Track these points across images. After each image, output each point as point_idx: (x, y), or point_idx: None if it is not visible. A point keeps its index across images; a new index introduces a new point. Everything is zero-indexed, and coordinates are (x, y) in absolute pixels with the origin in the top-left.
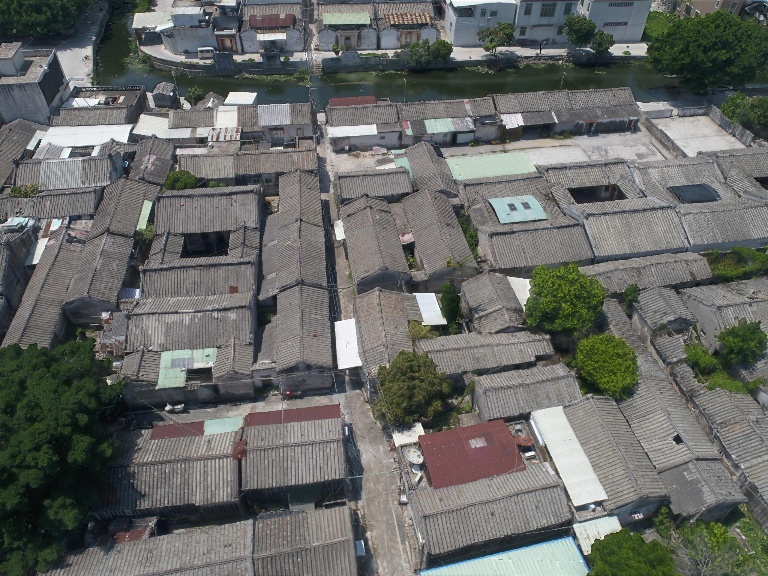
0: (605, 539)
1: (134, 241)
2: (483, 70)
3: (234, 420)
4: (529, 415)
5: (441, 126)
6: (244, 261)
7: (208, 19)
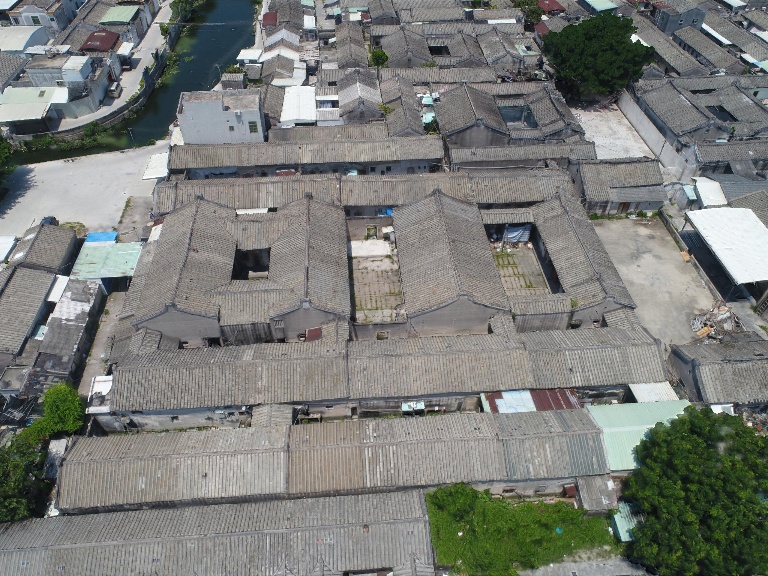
0: None
1: None
2: (201, 1)
3: None
4: None
5: (308, 2)
6: None
7: None
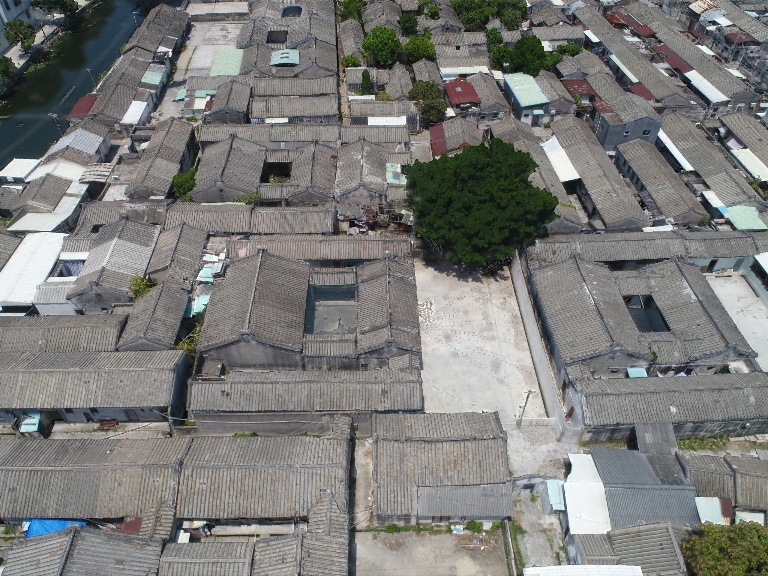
0: (514, 55)
1: None
2: (40, 66)
3: None
4: (442, 78)
5: (153, 77)
6: None
7: None
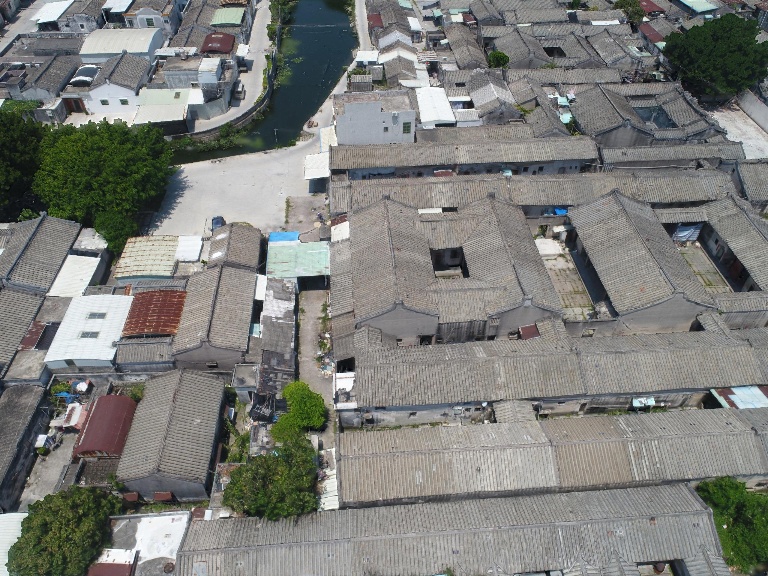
0: None
1: None
2: (292, 3)
3: (658, 44)
4: None
5: (405, 3)
6: None
7: None
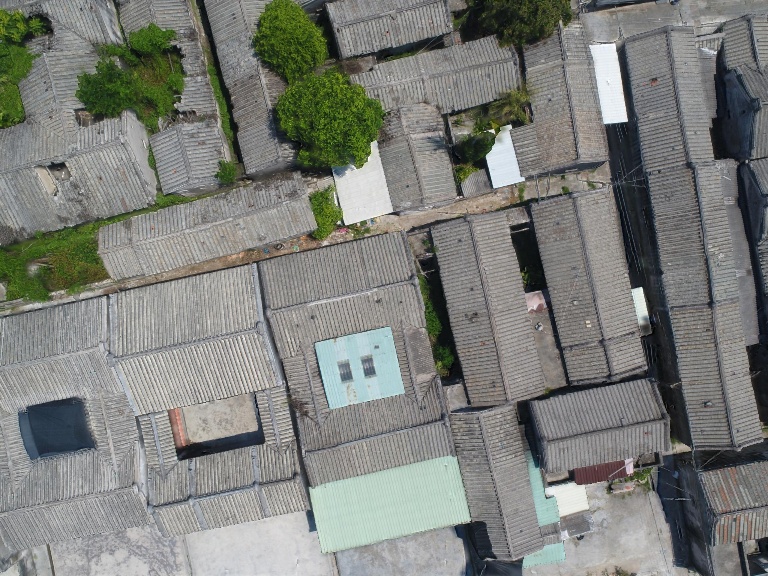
0: None
1: None
2: None
3: None
4: None
5: None
6: None
7: None
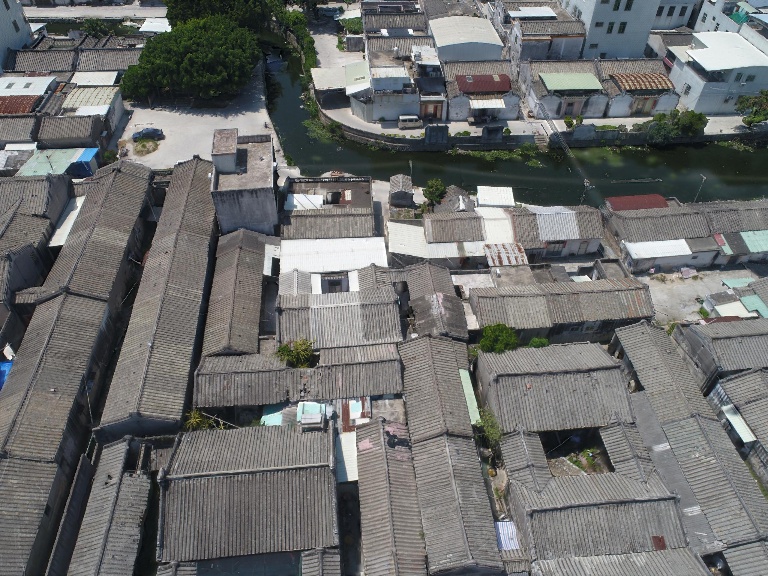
0: None
1: (475, 443)
2: (739, 147)
3: None
4: None
5: (764, 242)
6: (666, 496)
7: (413, 82)
